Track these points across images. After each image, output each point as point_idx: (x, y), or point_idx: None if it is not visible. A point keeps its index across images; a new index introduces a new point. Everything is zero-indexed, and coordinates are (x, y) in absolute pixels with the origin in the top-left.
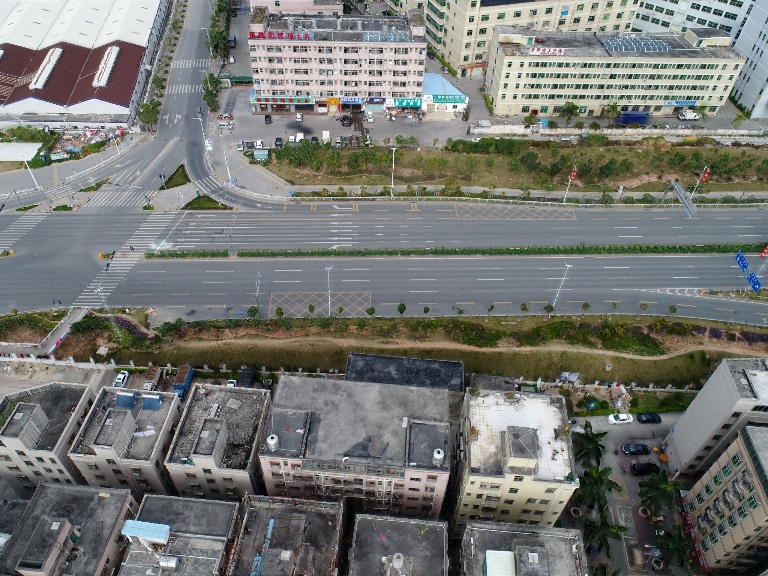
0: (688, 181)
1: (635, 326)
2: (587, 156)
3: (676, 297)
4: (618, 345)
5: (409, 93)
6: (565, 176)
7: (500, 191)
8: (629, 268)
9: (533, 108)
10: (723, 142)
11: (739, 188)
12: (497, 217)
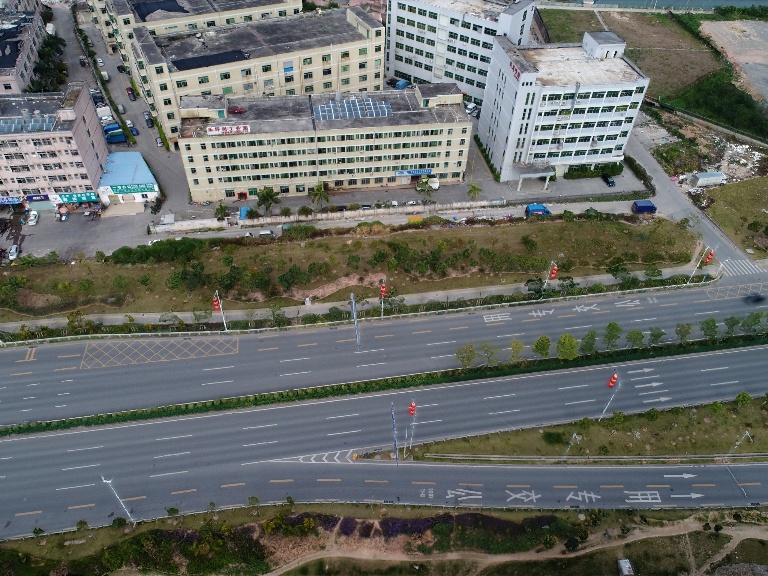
0: (395, 281)
1: (245, 527)
2: (282, 256)
3: (320, 467)
4: (207, 566)
5: (75, 187)
6: (244, 288)
7: (155, 318)
8: (276, 426)
9: (239, 191)
10: (458, 218)
11: (454, 285)
12: (134, 360)
